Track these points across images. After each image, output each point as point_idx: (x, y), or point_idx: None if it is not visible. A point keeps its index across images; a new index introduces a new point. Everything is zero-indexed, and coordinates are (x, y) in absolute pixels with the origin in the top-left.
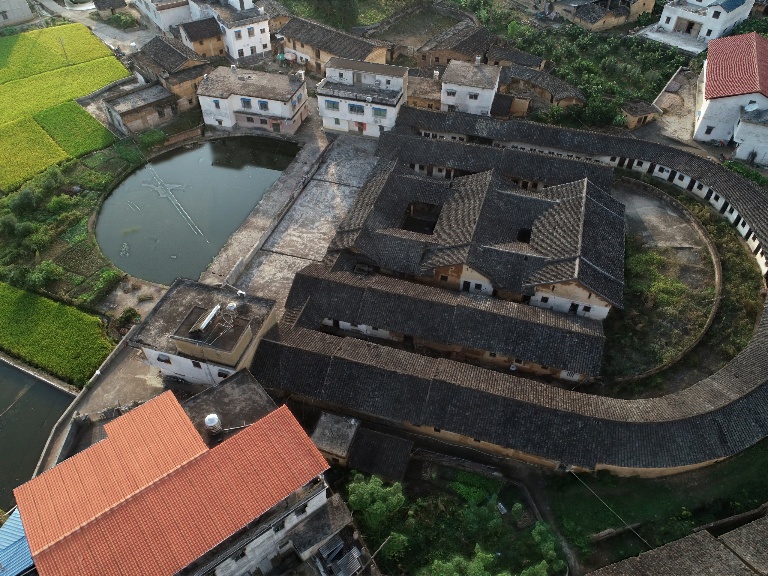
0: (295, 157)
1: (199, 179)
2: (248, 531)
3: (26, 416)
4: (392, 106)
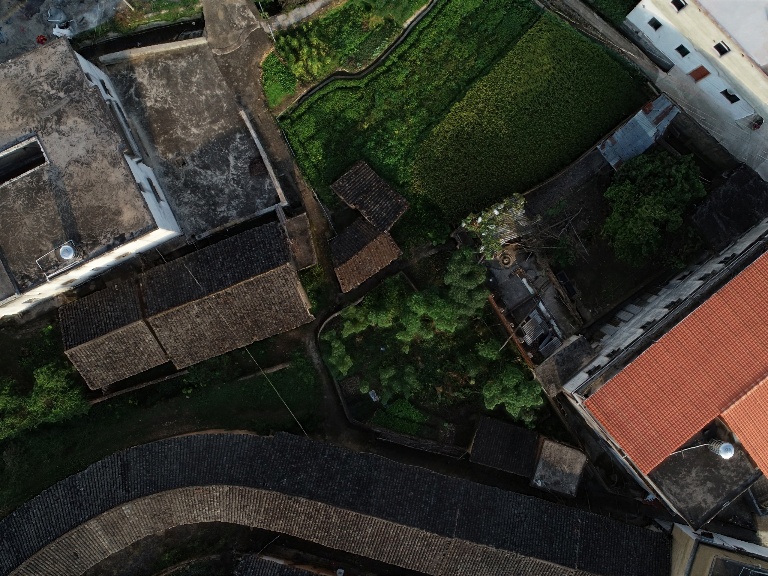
0: None
1: None
2: (648, 343)
3: None
4: None
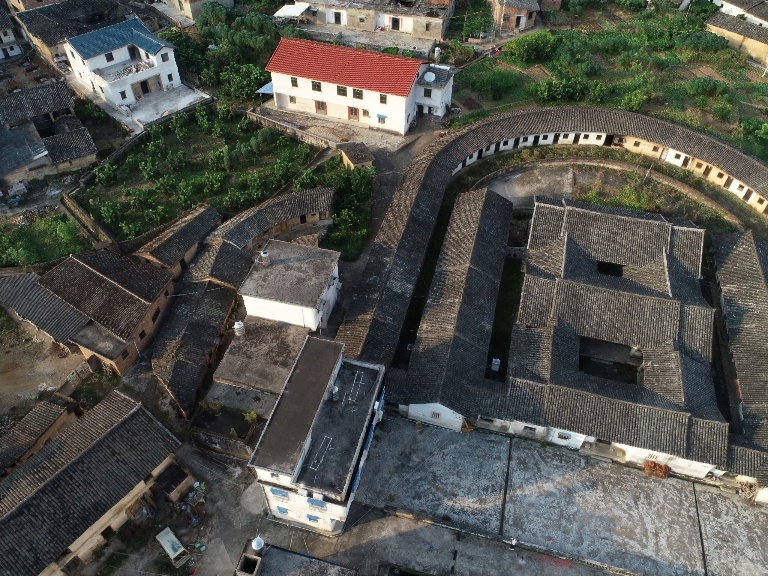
0: (438, 575)
1: None
2: None
3: None
4: None
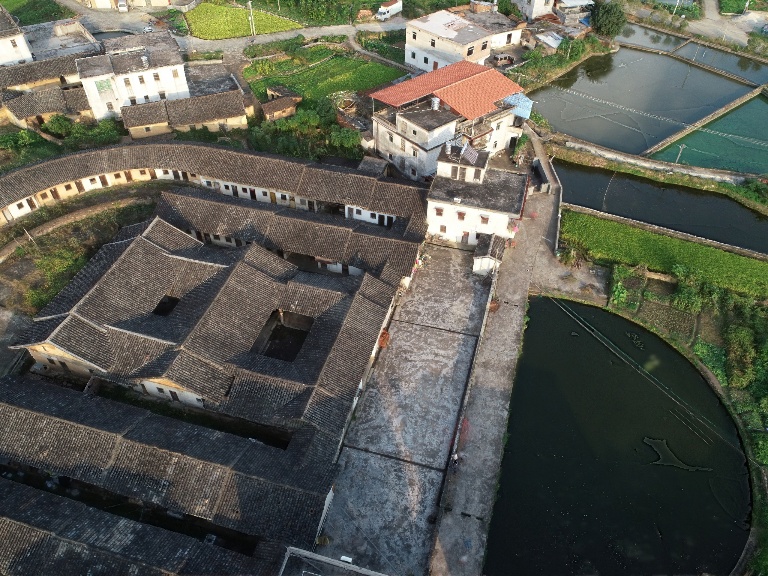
0: None
1: (628, 477)
2: None
3: (588, 195)
4: None
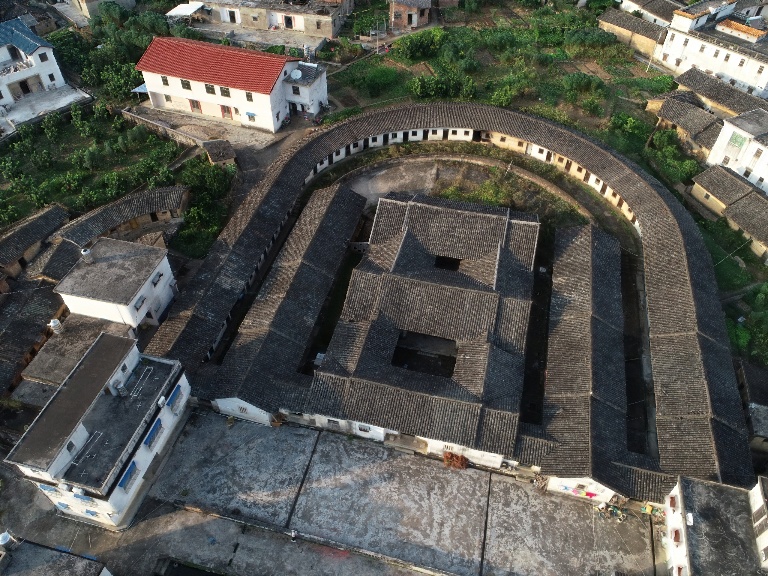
0: (214, 568)
1: None
2: None
3: None
4: (183, 372)
